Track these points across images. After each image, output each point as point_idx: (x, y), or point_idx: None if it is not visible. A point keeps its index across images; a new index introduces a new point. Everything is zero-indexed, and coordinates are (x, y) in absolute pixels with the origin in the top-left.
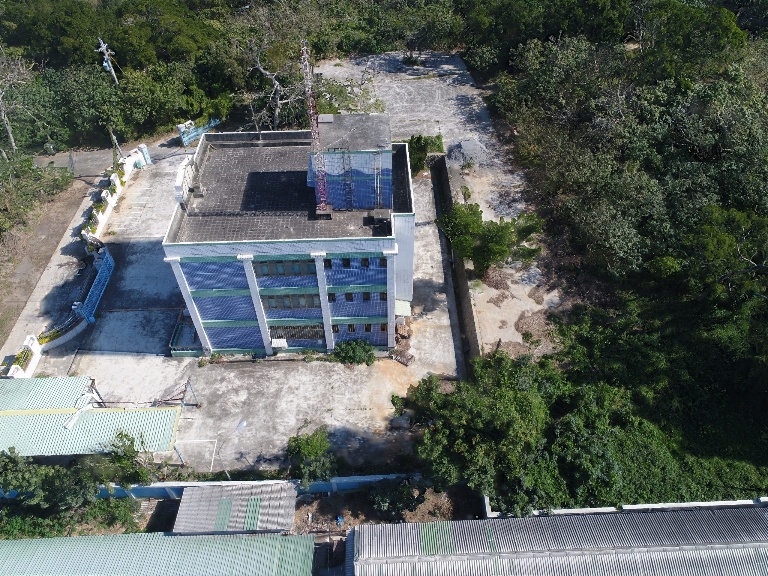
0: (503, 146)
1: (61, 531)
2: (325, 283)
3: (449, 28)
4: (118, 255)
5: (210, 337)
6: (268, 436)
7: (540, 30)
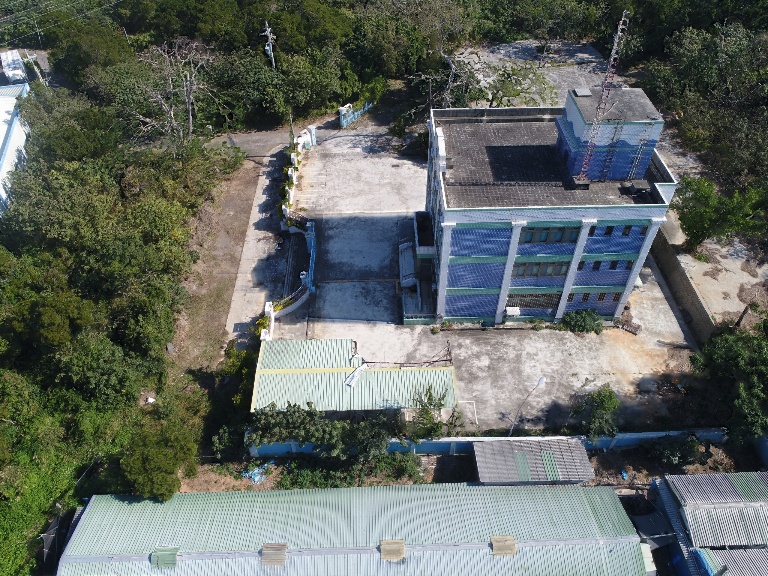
0: (666, 130)
1: (352, 483)
2: (582, 251)
3: (581, 18)
4: (316, 230)
5: (446, 305)
6: (523, 398)
7: (686, 19)
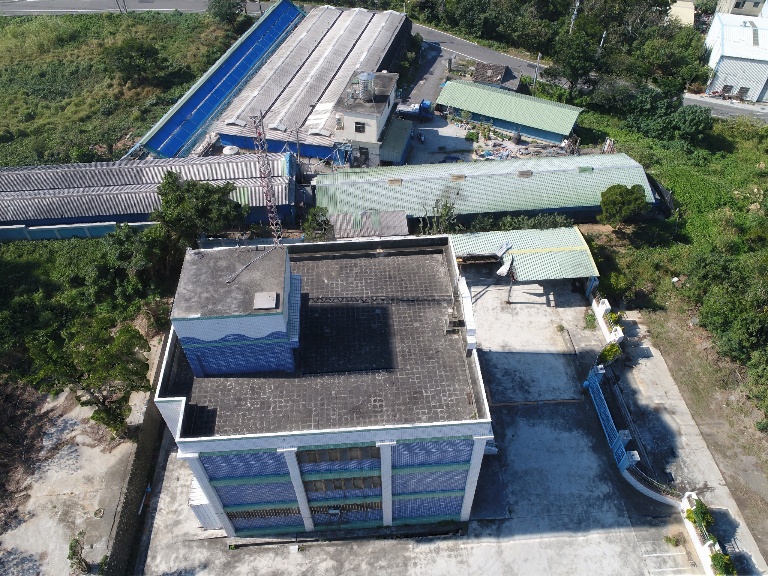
0: None
1: None
2: None
3: None
4: (629, 492)
5: None
6: None
7: None
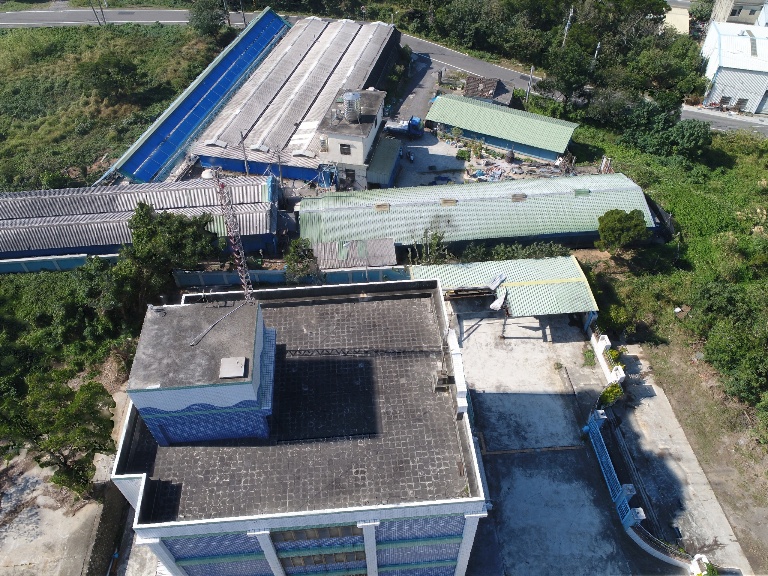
0: None
1: None
2: None
3: None
4: (634, 552)
5: None
6: None
7: None
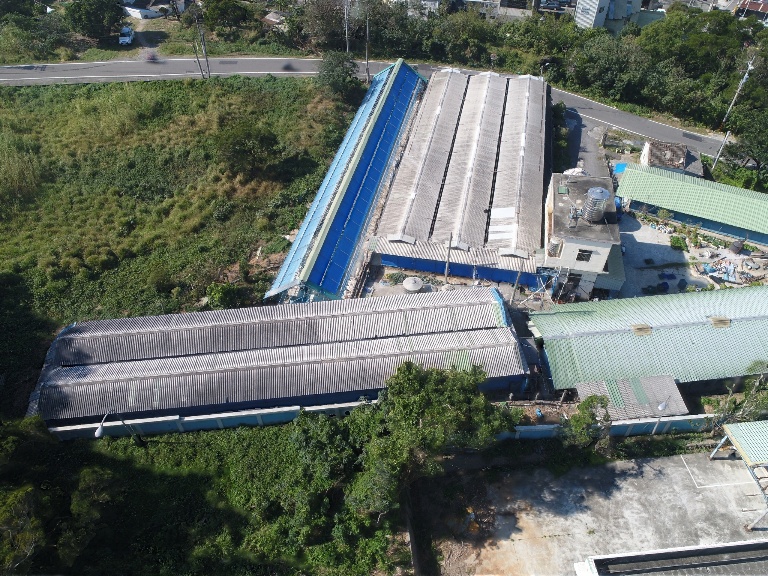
0: None
1: None
2: None
3: None
4: None
5: None
6: (645, 495)
7: None
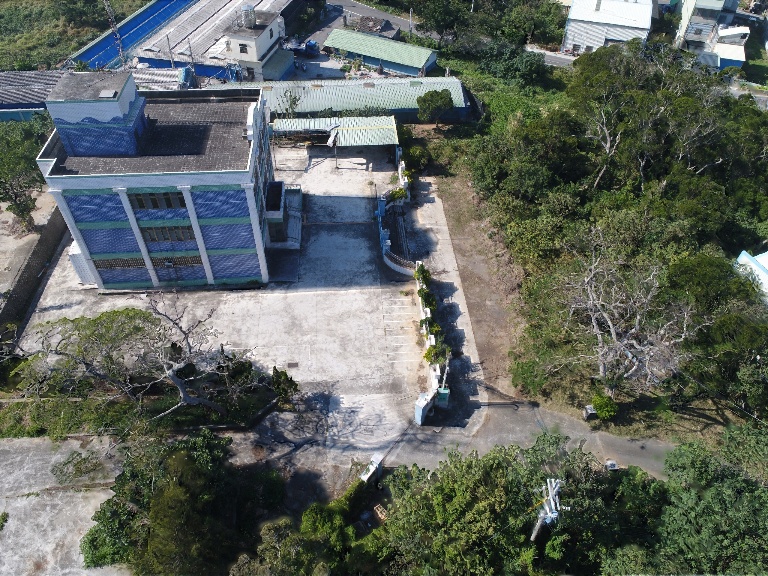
0: None
1: None
2: None
3: None
4: (385, 269)
5: None
6: None
7: None
